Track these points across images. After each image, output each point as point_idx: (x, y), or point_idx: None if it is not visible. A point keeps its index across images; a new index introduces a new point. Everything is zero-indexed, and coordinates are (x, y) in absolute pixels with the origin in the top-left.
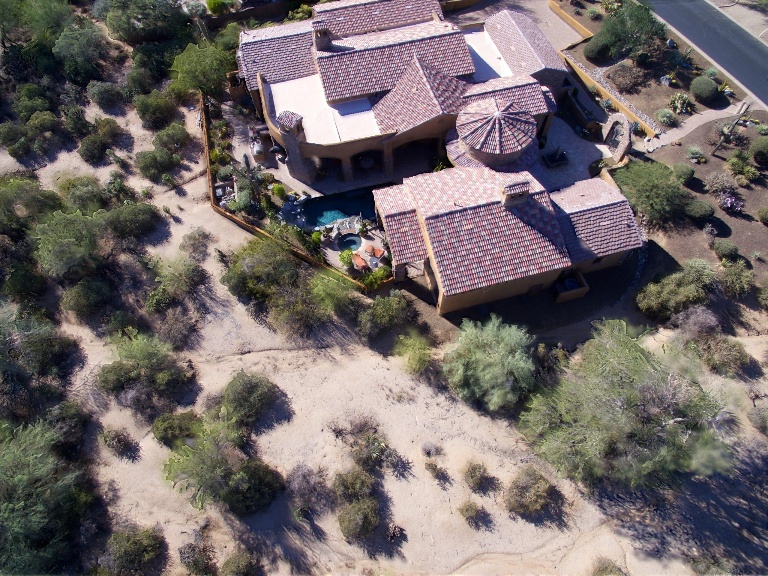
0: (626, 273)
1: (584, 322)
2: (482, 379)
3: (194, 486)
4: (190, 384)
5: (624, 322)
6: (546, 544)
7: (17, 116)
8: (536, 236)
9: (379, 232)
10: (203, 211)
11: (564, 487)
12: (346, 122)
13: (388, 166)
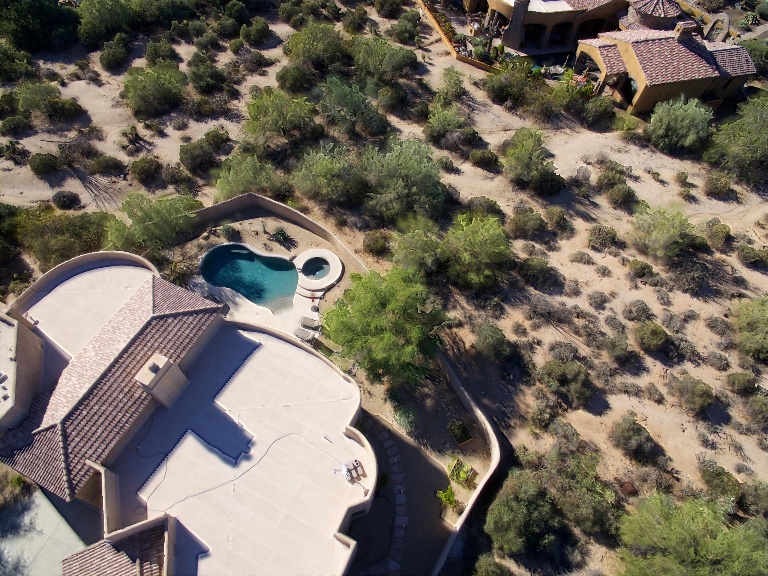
0: (739, 101)
1: (721, 121)
2: (679, 129)
3: None
4: (480, 141)
5: (760, 101)
6: (732, 210)
7: (279, 6)
8: (697, 58)
9: (575, 74)
10: (448, 59)
11: (735, 188)
12: (548, 5)
13: (571, 39)
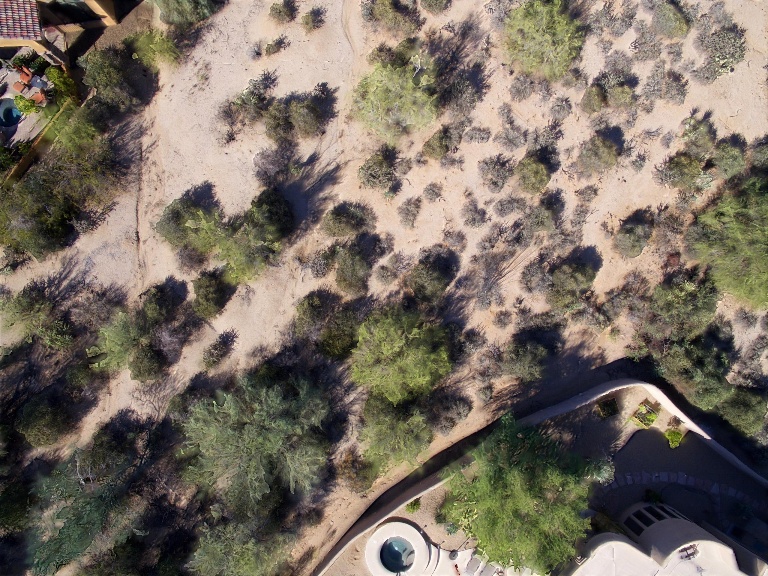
0: None
1: None
2: None
3: (257, 241)
4: (165, 290)
5: None
6: None
7: None
8: None
9: None
10: None
11: None
12: None
13: None
